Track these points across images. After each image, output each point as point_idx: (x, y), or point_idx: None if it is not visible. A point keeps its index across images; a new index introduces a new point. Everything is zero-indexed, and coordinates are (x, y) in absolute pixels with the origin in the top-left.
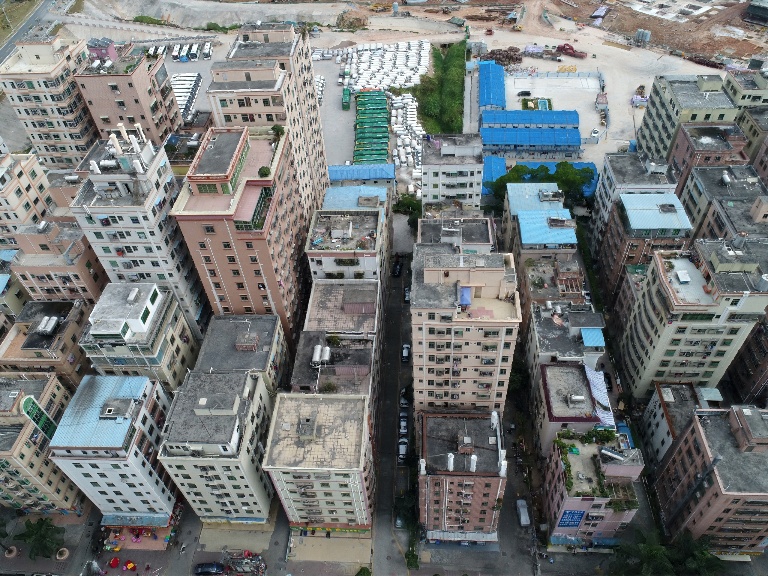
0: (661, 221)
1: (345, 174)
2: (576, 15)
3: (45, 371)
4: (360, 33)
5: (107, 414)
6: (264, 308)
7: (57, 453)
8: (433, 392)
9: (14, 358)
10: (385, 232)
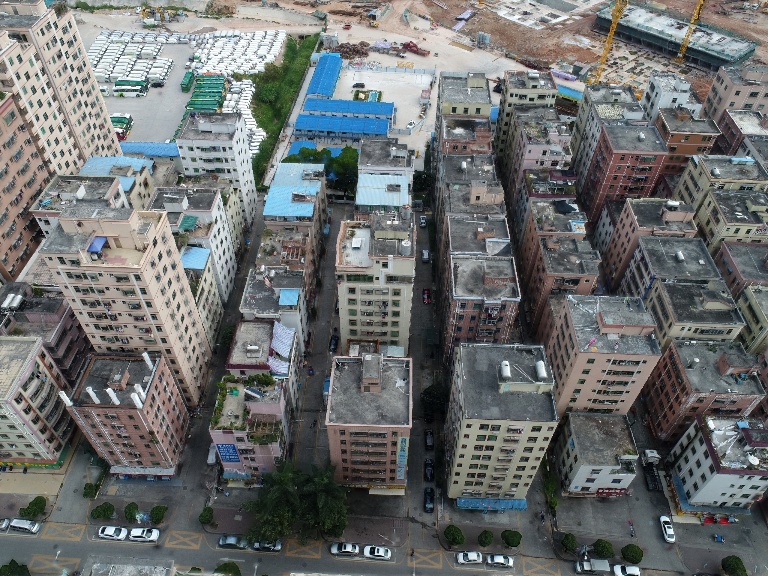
0: (383, 199)
1: (154, 150)
2: (443, 16)
3: None
4: (224, 20)
5: None
6: None
7: None
8: (104, 337)
9: None
10: (139, 200)
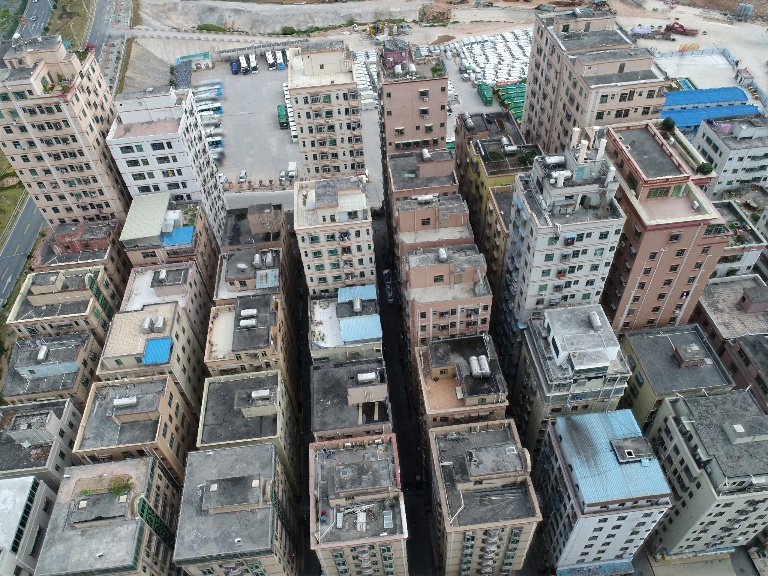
0: None
1: None
2: None
3: (481, 418)
4: (453, 26)
5: (630, 457)
6: (669, 318)
7: (586, 510)
8: None
9: (453, 408)
10: None
